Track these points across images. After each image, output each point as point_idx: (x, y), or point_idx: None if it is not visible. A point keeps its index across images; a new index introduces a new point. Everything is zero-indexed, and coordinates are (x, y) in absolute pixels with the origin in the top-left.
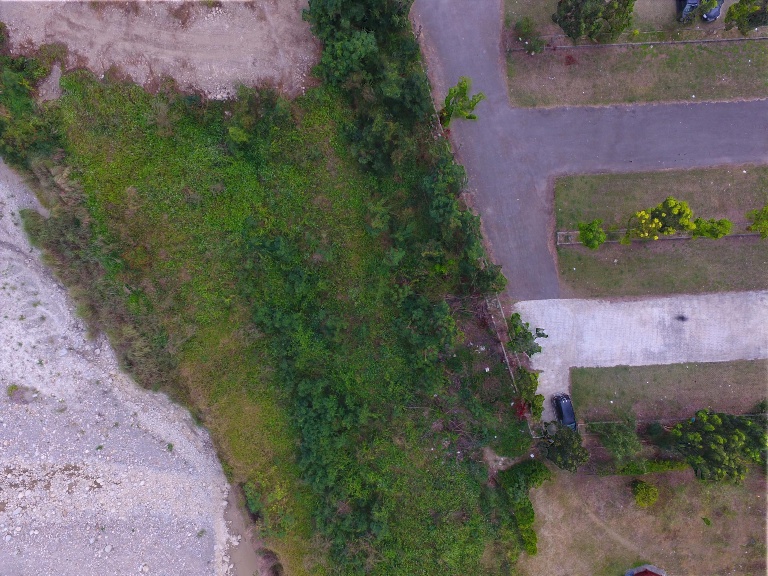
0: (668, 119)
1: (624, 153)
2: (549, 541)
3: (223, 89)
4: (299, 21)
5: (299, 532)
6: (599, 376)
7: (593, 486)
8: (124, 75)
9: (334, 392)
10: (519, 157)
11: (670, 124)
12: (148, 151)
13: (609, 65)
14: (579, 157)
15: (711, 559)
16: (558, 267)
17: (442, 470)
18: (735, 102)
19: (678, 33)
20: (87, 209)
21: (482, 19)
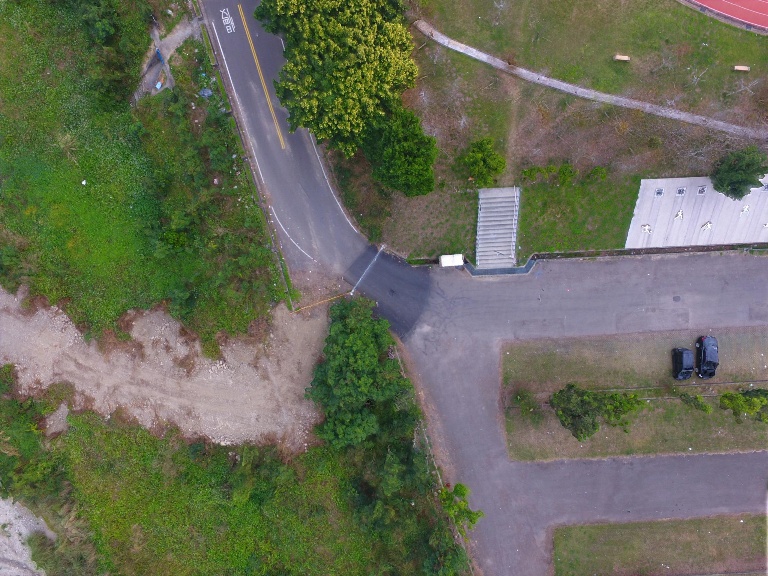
0: (665, 471)
1: (622, 504)
2: None
3: (227, 437)
4: (301, 381)
5: None
6: None
7: None
8: (130, 416)
9: None
10: (518, 509)
11: (667, 475)
12: (153, 491)
13: (606, 419)
14: (578, 508)
15: None
16: None
17: None
18: (731, 454)
19: (674, 390)
20: (93, 542)
21: (481, 377)
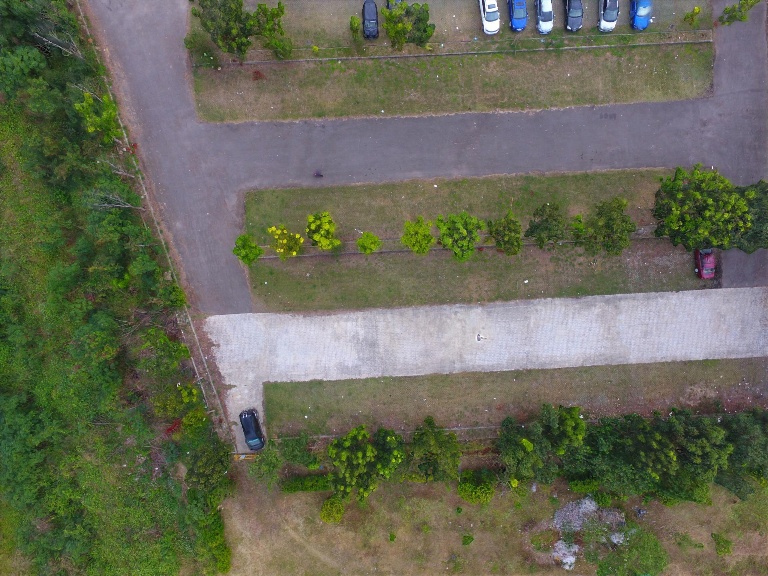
0: (358, 134)
1: (315, 167)
2: (247, 558)
3: None
4: None
5: (7, 551)
6: (293, 391)
7: (291, 502)
8: None
9: (39, 408)
10: (208, 171)
11: (360, 139)
12: None
13: (297, 80)
14: (269, 171)
15: (413, 575)
16: (250, 281)
17: (133, 487)
18: (424, 117)
19: (364, 49)
20: None
21: (168, 35)
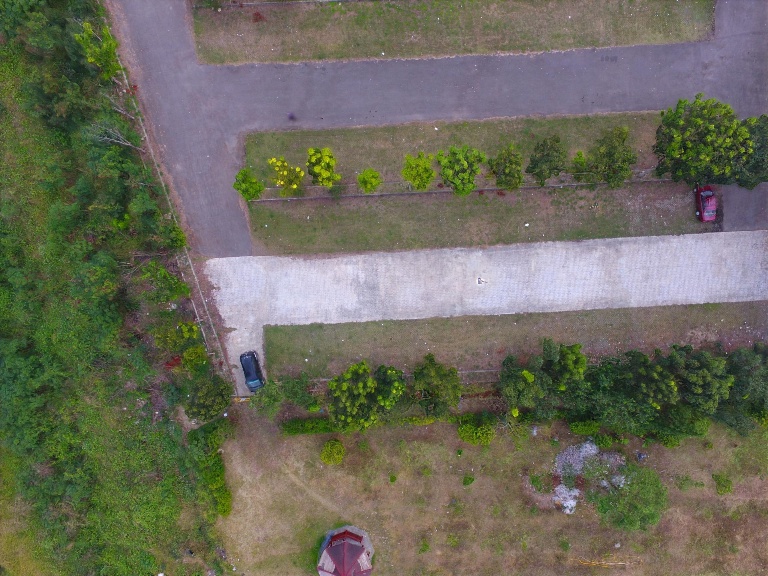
0: (358, 76)
1: (315, 110)
2: (248, 502)
3: None
4: None
5: (8, 497)
6: (293, 334)
7: (291, 446)
8: None
9: (39, 353)
10: (208, 114)
11: (360, 81)
12: None
13: (297, 22)
14: (269, 114)
15: (413, 520)
16: (250, 224)
17: (133, 430)
18: (425, 59)
19: None
20: None
21: None
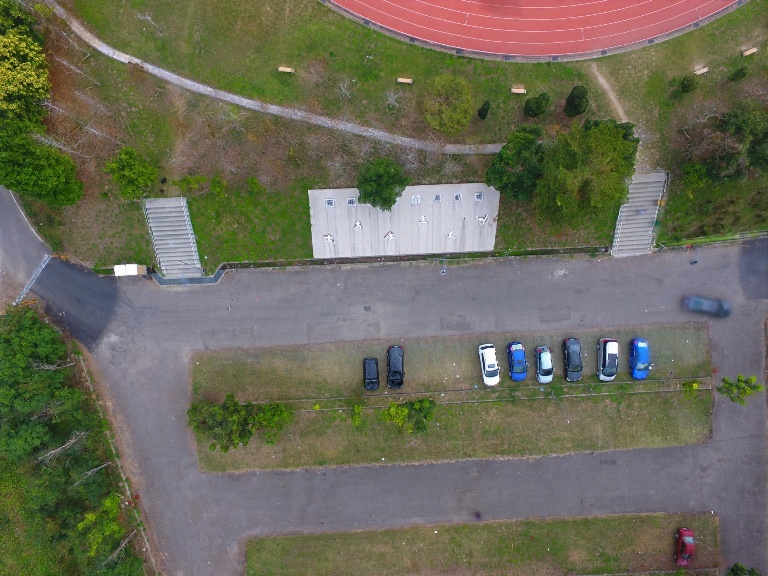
0: (359, 481)
1: (315, 515)
2: None
3: None
4: None
5: None
6: None
7: None
8: None
9: None
10: (210, 521)
11: (361, 486)
12: None
13: (298, 430)
14: (270, 520)
15: None
16: None
17: None
18: (425, 464)
19: (365, 400)
20: None
21: (170, 387)
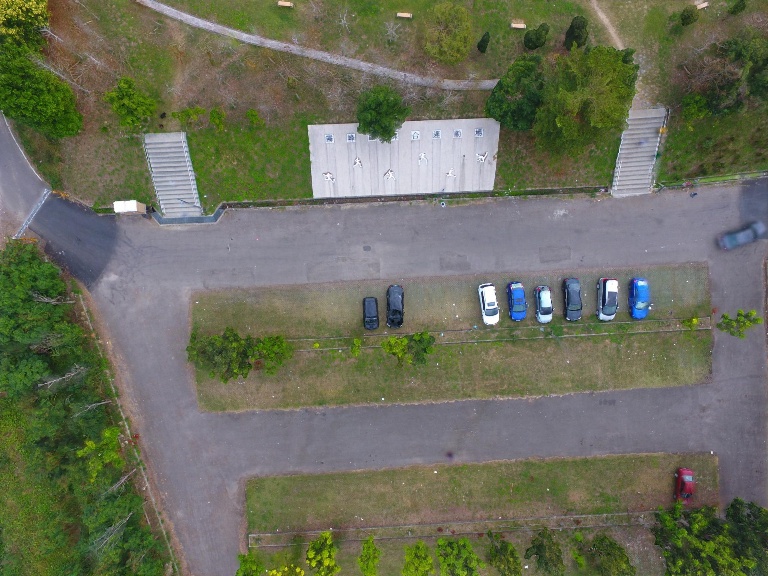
0: (358, 421)
1: (315, 455)
2: None
3: None
4: None
5: None
6: None
7: None
8: None
9: None
10: (209, 460)
11: (360, 426)
12: None
13: (298, 369)
14: (270, 459)
15: None
16: None
17: None
18: (424, 404)
19: (364, 339)
20: None
21: (170, 327)
